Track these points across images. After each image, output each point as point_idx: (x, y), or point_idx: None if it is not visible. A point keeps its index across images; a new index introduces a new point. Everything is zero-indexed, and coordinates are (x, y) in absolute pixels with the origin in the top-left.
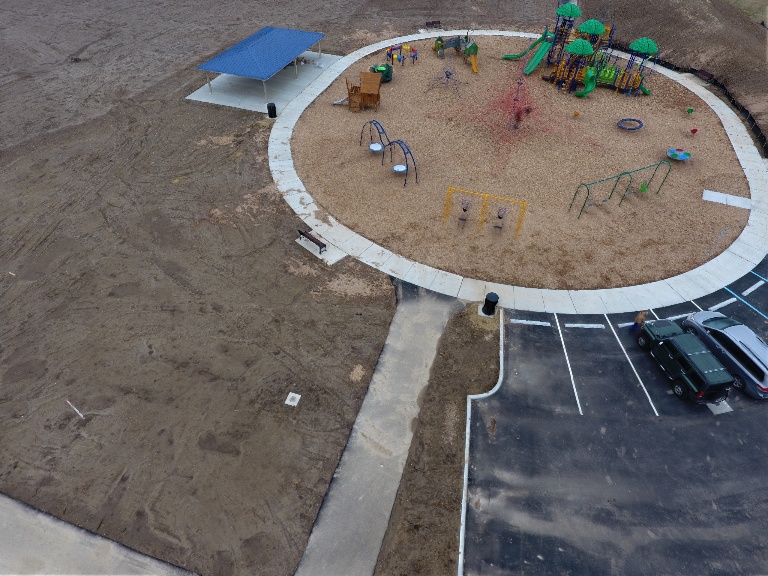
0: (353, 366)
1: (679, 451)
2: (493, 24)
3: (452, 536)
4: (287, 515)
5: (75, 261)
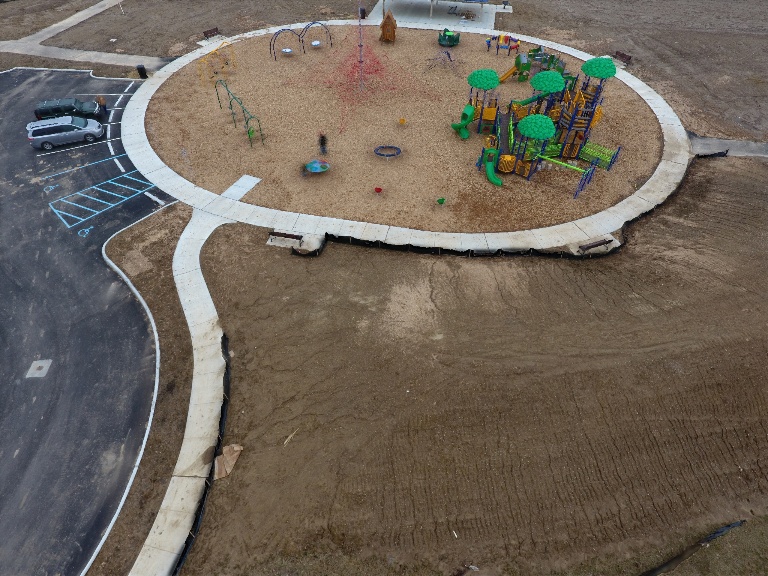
0: (124, 49)
1: (31, 115)
2: (681, 94)
3: (36, 66)
4: (65, 43)
5: (212, 0)
